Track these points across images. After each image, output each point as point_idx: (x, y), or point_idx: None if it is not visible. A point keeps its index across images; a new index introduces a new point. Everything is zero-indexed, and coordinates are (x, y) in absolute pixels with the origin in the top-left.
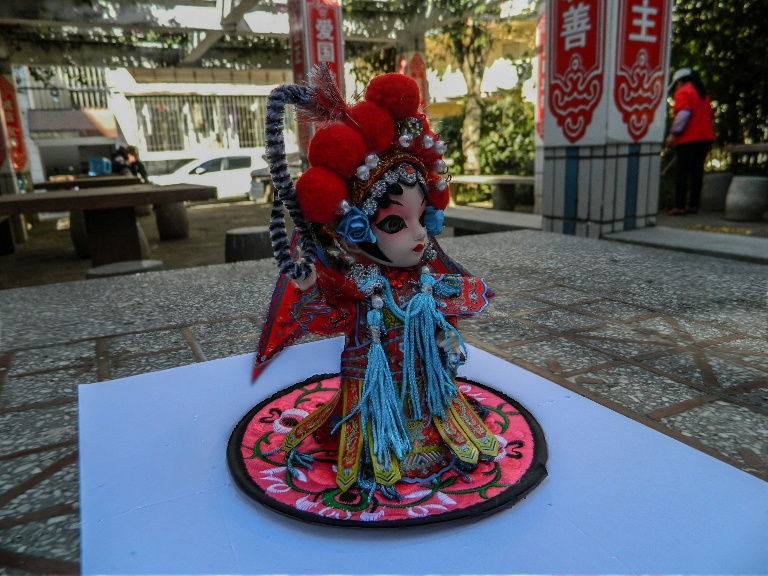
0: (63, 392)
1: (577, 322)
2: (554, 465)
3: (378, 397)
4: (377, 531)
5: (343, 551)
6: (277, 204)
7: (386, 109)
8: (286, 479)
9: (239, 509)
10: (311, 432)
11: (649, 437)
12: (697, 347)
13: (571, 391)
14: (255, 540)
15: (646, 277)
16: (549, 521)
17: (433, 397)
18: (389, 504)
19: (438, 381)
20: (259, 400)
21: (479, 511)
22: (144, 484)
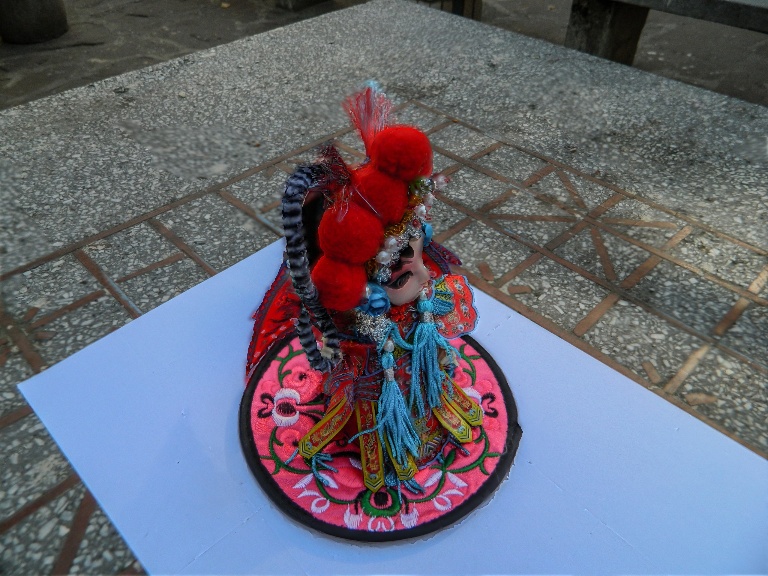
0: (5, 399)
1: (486, 191)
2: (522, 415)
3: (393, 417)
4: (423, 538)
5: (399, 557)
6: (305, 317)
7: (401, 181)
8: (320, 490)
9: (293, 532)
10: (328, 441)
11: (581, 362)
12: (591, 219)
13: (509, 308)
14: (323, 564)
15: (528, 98)
16: (534, 481)
17: (434, 397)
18: (417, 499)
19: (437, 383)
20: (234, 373)
21: (489, 494)
22: (188, 523)
